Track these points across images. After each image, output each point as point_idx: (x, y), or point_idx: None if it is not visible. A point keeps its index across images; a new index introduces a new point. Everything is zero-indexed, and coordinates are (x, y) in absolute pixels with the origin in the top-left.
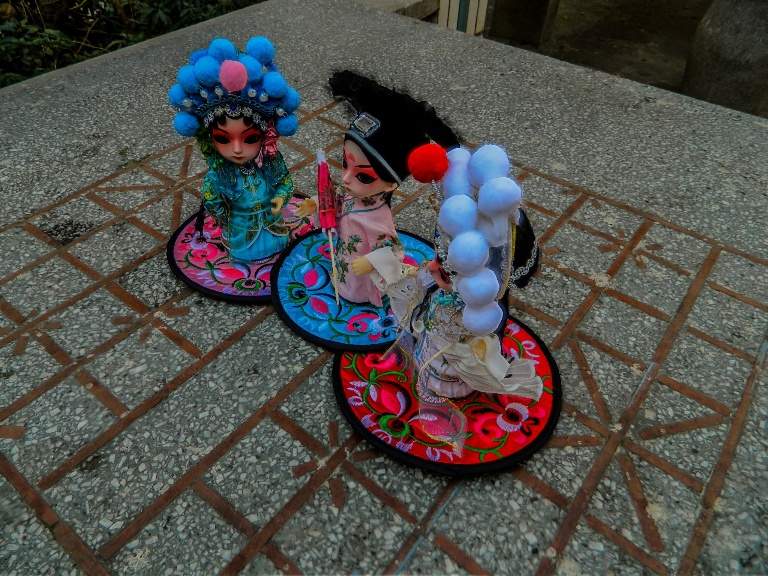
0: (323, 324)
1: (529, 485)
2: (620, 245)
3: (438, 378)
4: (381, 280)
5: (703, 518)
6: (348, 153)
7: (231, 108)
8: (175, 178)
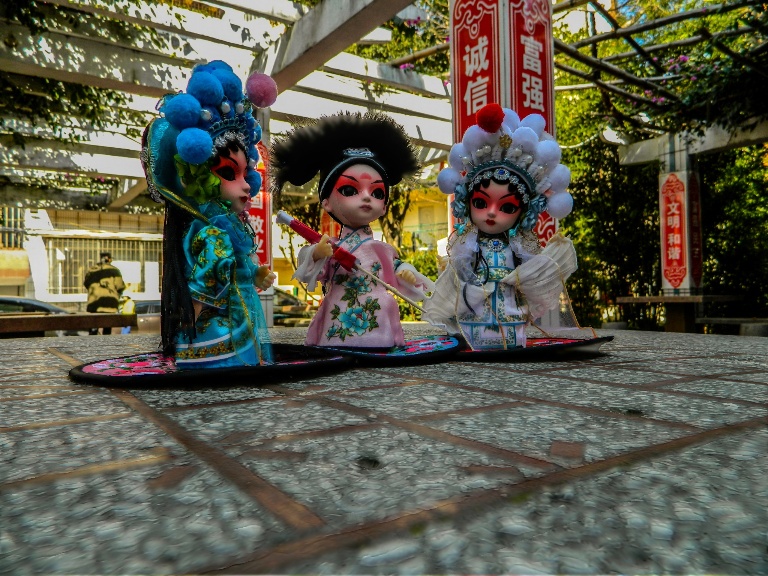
0: None
1: None
2: None
3: (522, 323)
4: (423, 287)
5: None
6: (360, 174)
7: (242, 134)
8: None
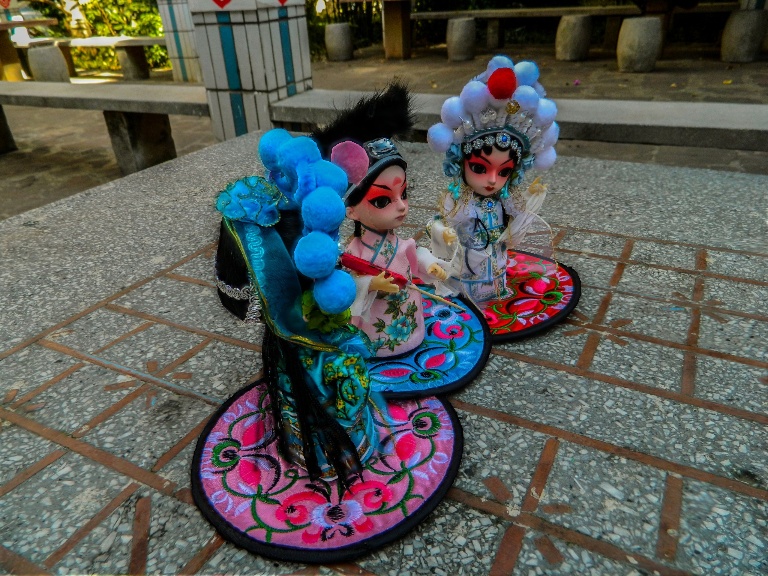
0: (462, 352)
1: None
2: None
3: None
4: None
5: None
6: (393, 181)
7: None
8: None
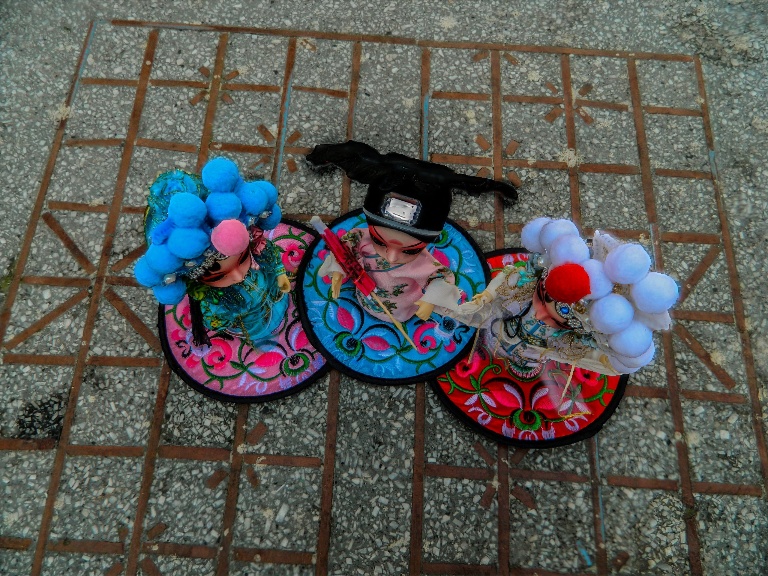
0: (397, 361)
1: (637, 396)
2: (560, 104)
3: None
4: None
5: (744, 342)
6: (390, 239)
7: None
8: (82, 274)
